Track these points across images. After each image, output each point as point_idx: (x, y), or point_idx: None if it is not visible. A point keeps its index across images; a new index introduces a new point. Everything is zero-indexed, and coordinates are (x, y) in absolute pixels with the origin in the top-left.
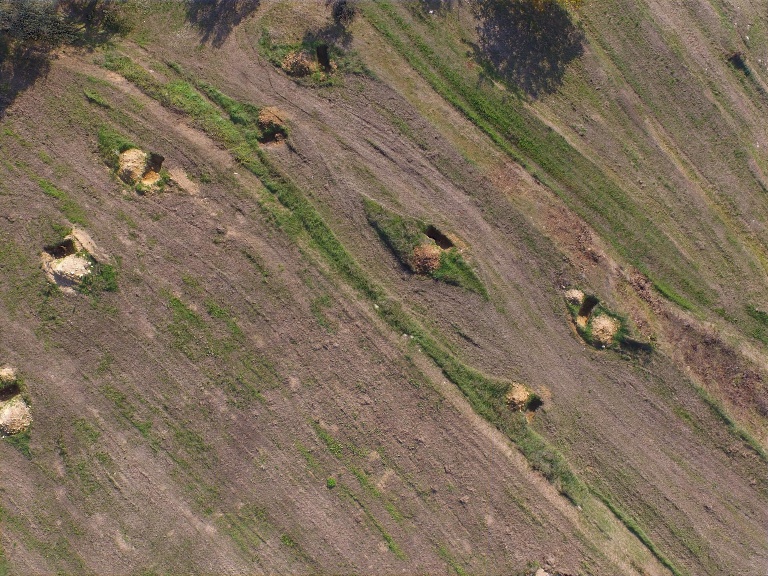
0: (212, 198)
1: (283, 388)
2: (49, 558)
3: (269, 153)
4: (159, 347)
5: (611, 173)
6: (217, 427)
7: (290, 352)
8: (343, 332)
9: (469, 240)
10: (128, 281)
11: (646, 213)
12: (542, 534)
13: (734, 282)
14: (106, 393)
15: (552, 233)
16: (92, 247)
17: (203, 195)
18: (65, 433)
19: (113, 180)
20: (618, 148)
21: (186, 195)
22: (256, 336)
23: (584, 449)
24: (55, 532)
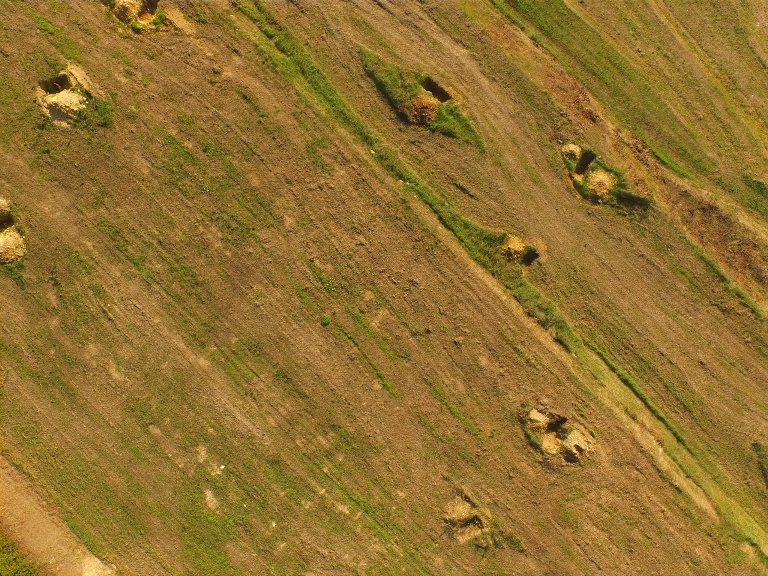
0: (208, 39)
1: (278, 227)
2: (42, 386)
3: (266, 3)
4: (154, 183)
5: (610, 39)
6: (211, 263)
7: (285, 192)
8: (339, 174)
9: (466, 93)
10: (123, 118)
11: (645, 80)
12: (536, 376)
13: (732, 152)
14: (100, 226)
15: (550, 90)
16: (87, 83)
17: (199, 35)
18: (59, 265)
19: (109, 18)
20: (617, 16)
21: (182, 35)
22: (251, 175)
23: (579, 302)
24: (48, 361)
